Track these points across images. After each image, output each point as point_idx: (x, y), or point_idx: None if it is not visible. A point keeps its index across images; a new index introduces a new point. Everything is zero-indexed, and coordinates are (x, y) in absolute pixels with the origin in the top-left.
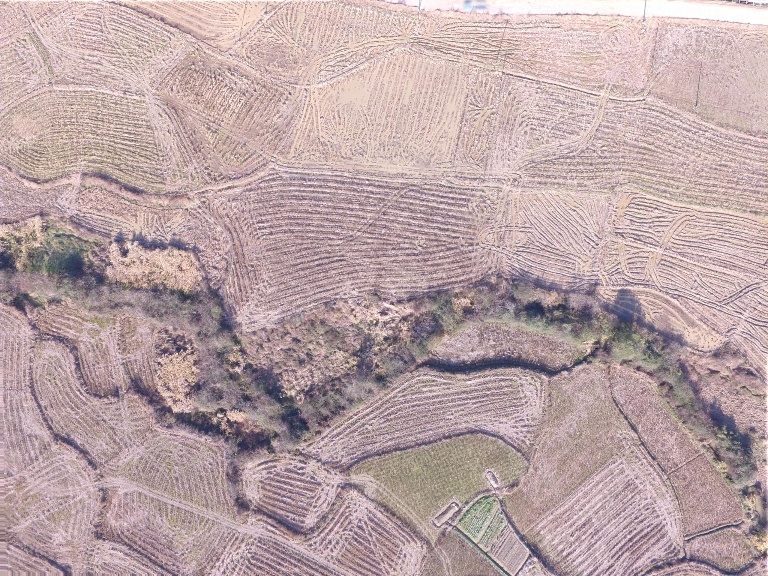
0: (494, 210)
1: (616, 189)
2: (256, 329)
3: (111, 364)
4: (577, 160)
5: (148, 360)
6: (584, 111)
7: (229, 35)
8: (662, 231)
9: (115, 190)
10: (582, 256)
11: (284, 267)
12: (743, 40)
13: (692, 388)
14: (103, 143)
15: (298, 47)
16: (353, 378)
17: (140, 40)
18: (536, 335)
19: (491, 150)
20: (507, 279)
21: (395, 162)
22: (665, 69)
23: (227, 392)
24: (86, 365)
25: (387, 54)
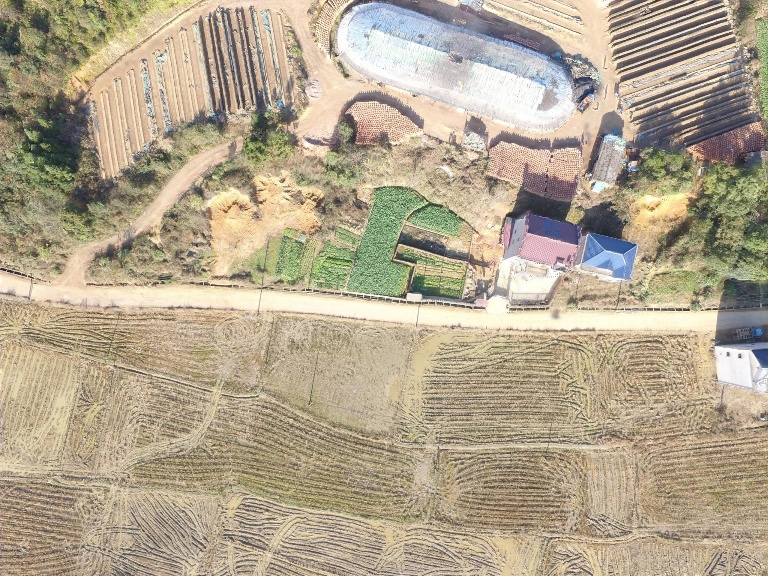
0: (101, 511)
1: (225, 490)
2: None
3: None
4: (186, 460)
5: None
6: (196, 408)
7: None
8: (272, 534)
9: None
10: (189, 560)
11: None
12: (360, 335)
13: None
14: None
15: None
16: None
17: None
18: None
19: (99, 448)
20: None
21: (1, 459)
22: (280, 365)
23: None
24: None
25: None
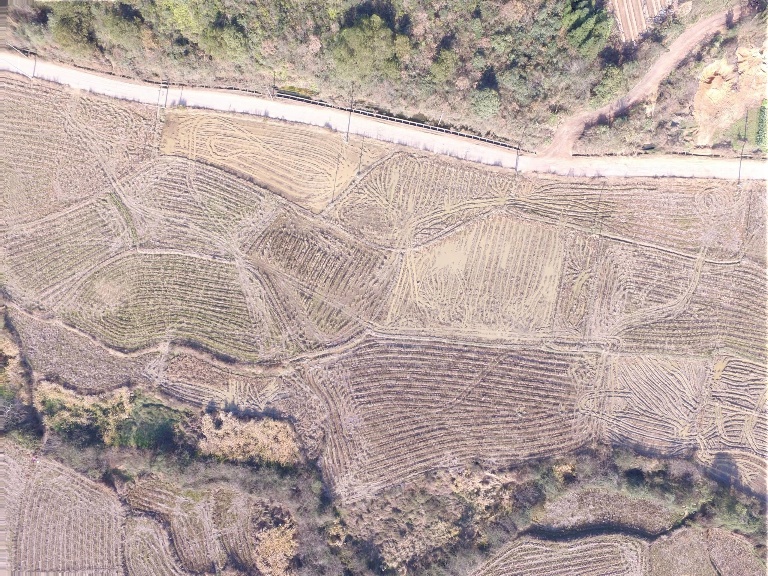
0: (593, 375)
1: (713, 353)
2: (356, 501)
3: (206, 539)
4: (675, 324)
5: (244, 533)
6: (681, 274)
7: (321, 196)
8: (758, 394)
9: (206, 359)
10: (680, 420)
11: (383, 436)
12: None
13: None
14: (192, 310)
15: (393, 209)
16: (456, 550)
17: (228, 201)
18: (635, 499)
19: (590, 315)
20: (607, 445)
21: (494, 328)
22: (759, 231)
23: (329, 569)
24: (180, 540)
25: (484, 216)
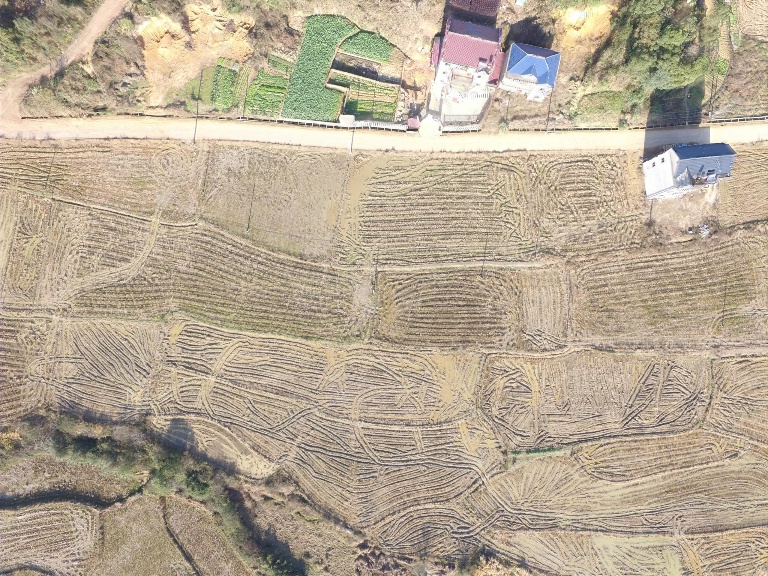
0: (44, 341)
1: (167, 317)
2: None
3: None
4: (127, 288)
5: None
6: (135, 237)
7: None
8: (214, 358)
9: None
10: (133, 386)
11: None
12: (296, 161)
13: (239, 518)
14: None
15: None
16: None
17: None
18: (92, 466)
19: (40, 280)
20: (56, 412)
21: None
22: (217, 193)
23: None
24: None
25: None
